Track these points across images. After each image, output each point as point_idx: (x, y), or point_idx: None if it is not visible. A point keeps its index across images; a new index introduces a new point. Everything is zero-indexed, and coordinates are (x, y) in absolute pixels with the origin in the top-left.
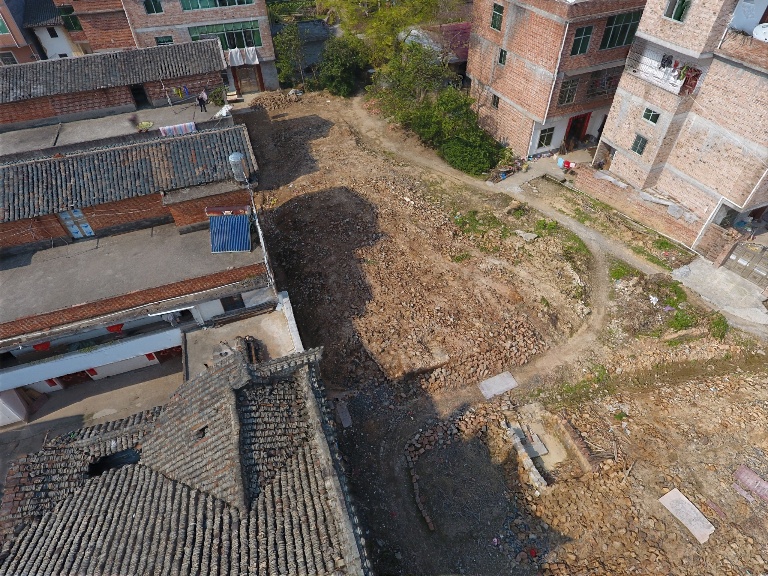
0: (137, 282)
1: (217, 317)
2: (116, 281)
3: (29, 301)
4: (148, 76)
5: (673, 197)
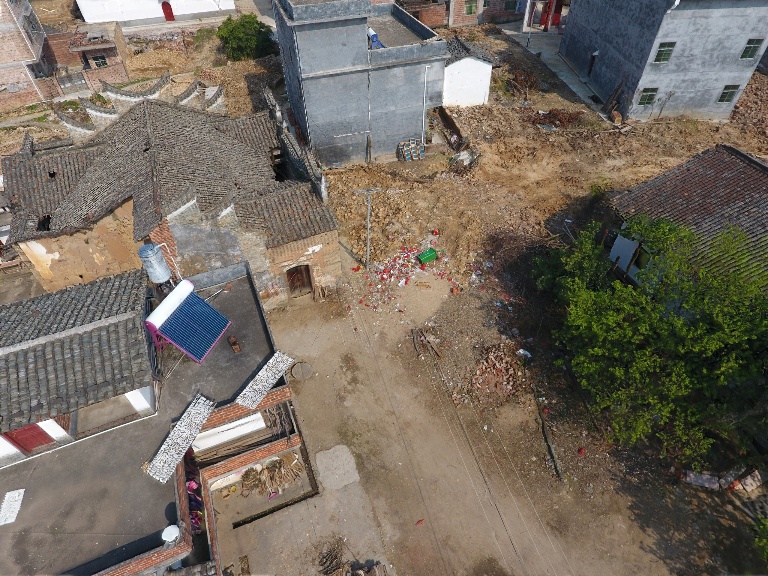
0: None
1: None
2: None
3: None
4: None
5: (1, 84)
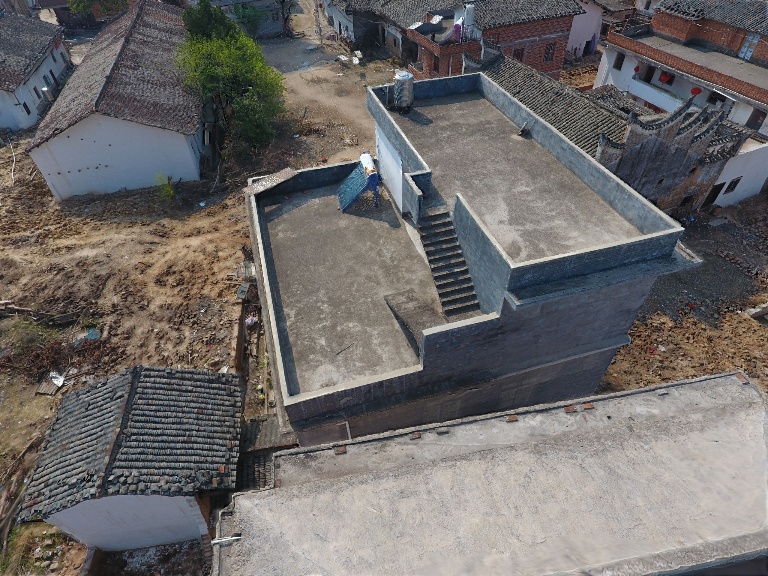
0: None
1: None
2: None
3: None
4: None
5: None
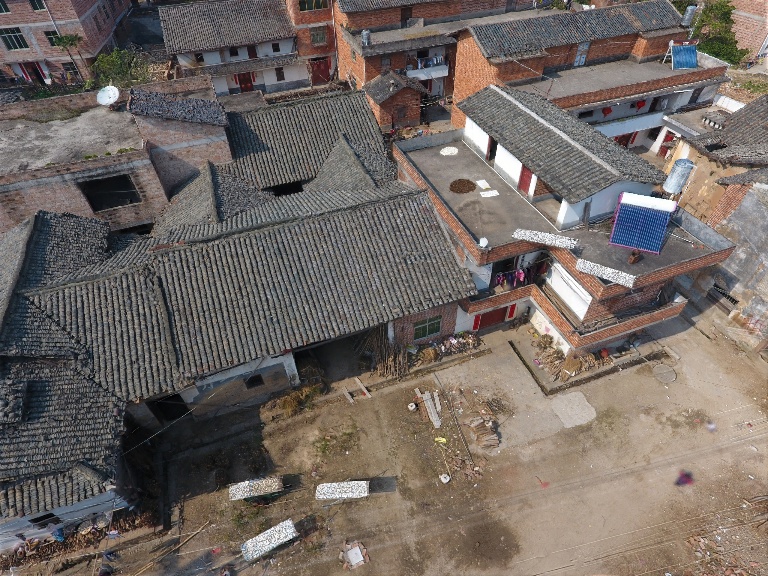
0: None
1: (684, 106)
2: (631, 81)
3: (590, 89)
4: None
5: None
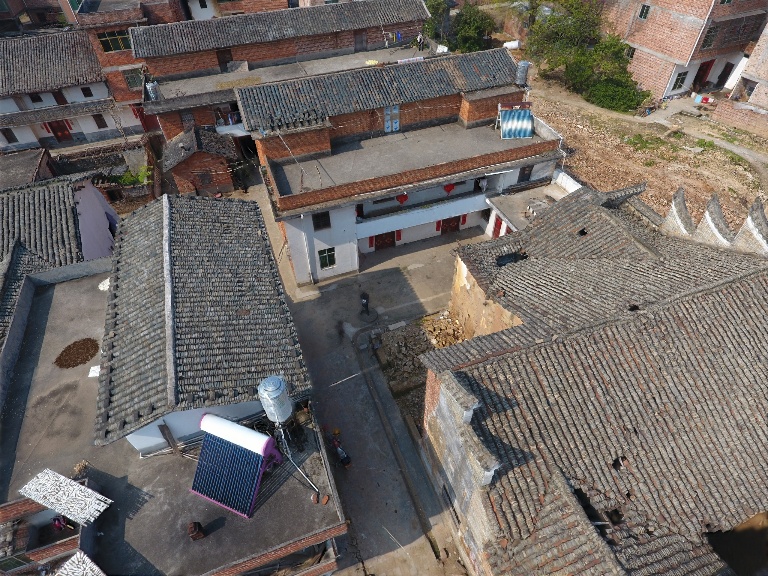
0: (459, 156)
1: (512, 186)
2: (441, 156)
3: (385, 168)
4: (371, 22)
5: None
